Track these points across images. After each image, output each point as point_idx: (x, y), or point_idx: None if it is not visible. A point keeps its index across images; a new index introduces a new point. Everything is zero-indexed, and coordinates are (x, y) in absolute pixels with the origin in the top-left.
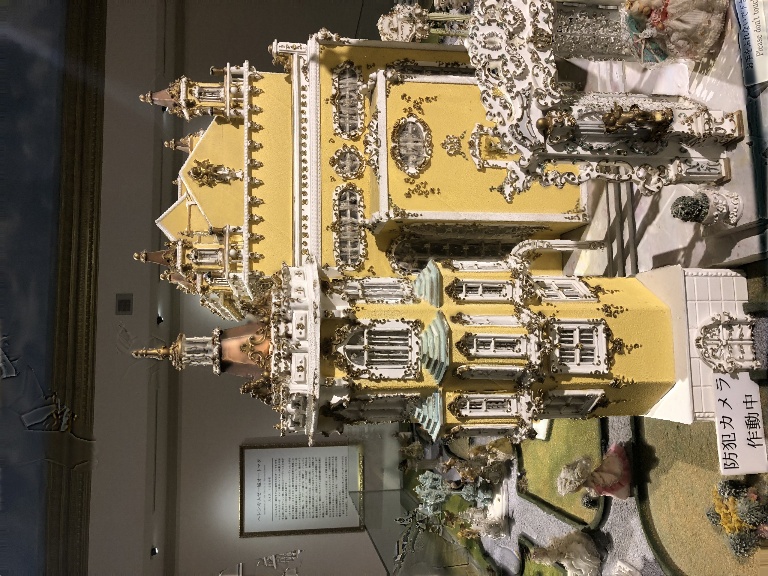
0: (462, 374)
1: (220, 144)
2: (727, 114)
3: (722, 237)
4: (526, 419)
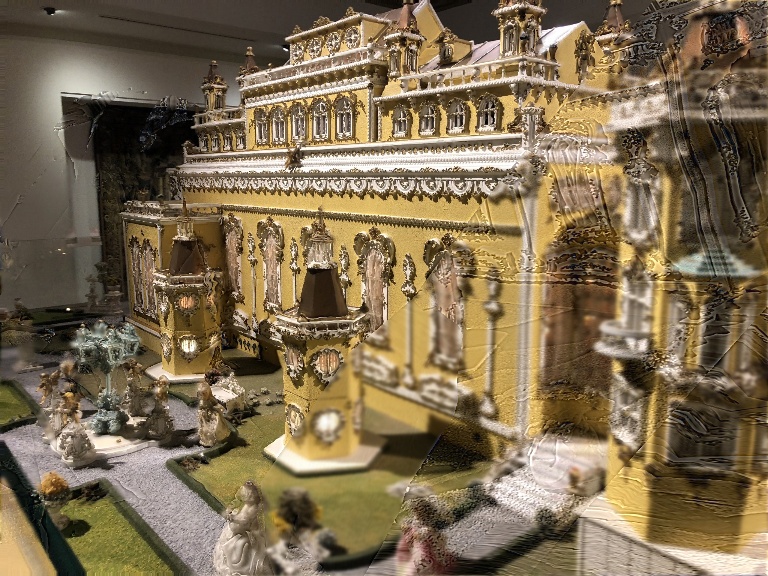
0: None
1: None
2: None
3: None
4: None
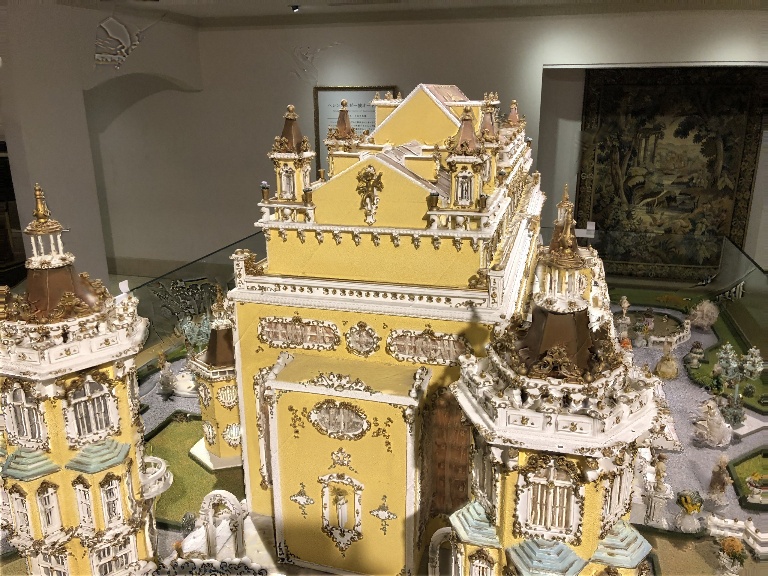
0: None
1: (405, 199)
2: None
3: None
4: None
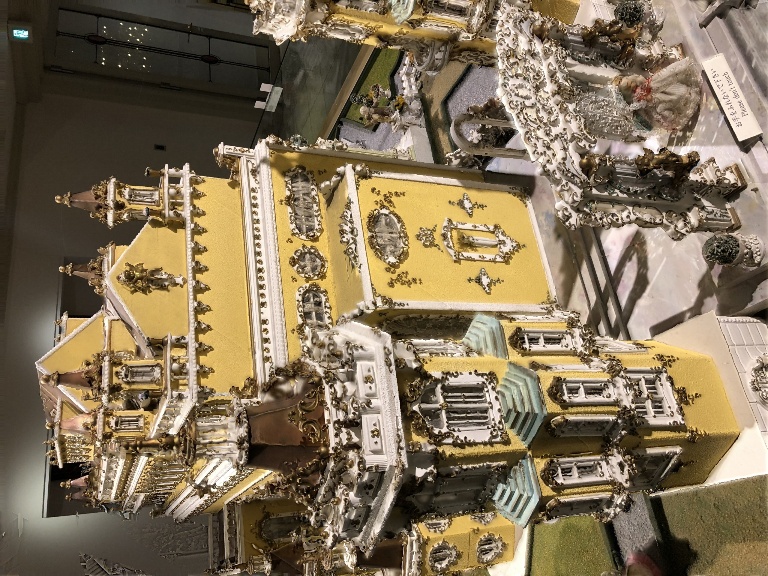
0: (555, 429)
1: (155, 248)
2: (727, 167)
3: (737, 286)
4: (623, 482)
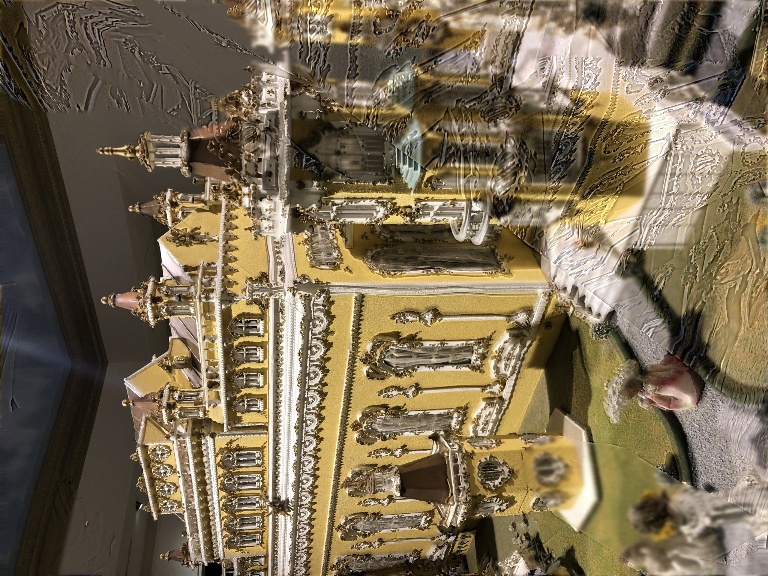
0: None
1: None
2: None
3: None
4: None
